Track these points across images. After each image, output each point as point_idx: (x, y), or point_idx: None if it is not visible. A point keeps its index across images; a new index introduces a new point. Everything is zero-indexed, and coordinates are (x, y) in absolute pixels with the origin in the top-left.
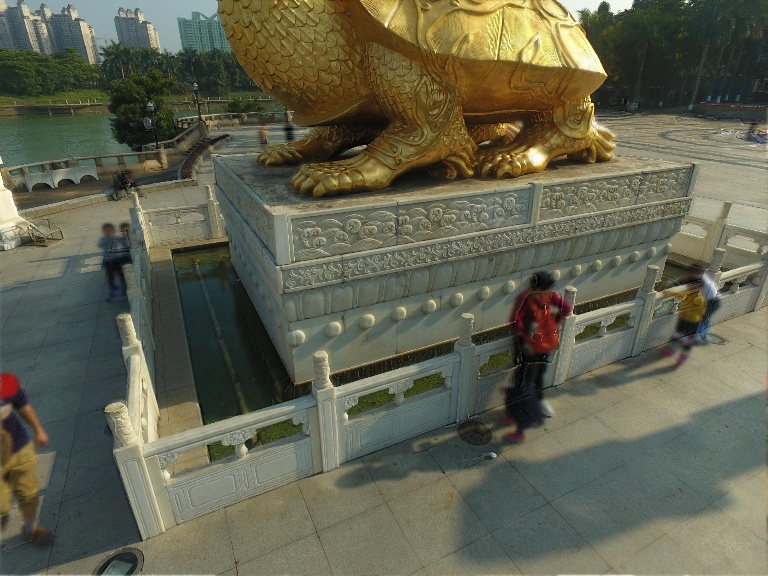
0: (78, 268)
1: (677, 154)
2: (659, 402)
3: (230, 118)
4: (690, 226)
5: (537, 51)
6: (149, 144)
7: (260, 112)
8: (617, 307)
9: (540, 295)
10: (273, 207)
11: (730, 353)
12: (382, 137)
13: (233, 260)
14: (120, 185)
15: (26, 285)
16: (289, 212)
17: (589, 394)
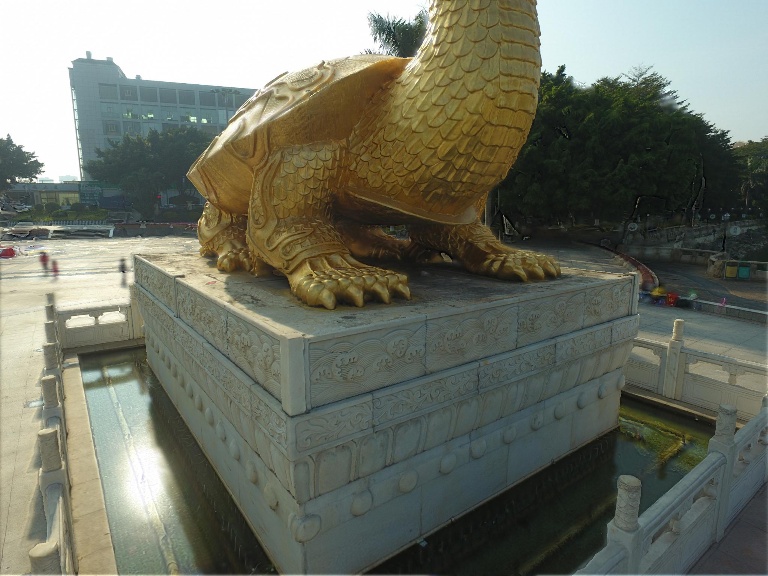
0: None
1: None
2: None
3: None
4: None
5: None
6: None
7: None
8: None
9: None
10: None
11: None
12: (480, 227)
13: None
14: None
15: None
16: None
17: None
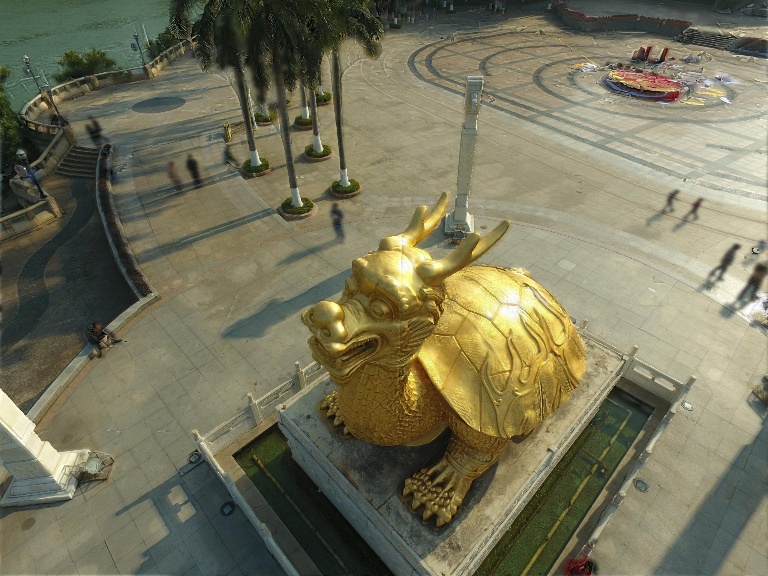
0: (174, 514)
1: (558, 130)
2: (629, 570)
3: (77, 86)
4: (599, 310)
5: (561, 396)
6: (16, 177)
7: (111, 70)
8: (606, 522)
9: (585, 573)
10: (426, 561)
11: (652, 501)
12: (462, 456)
13: (299, 463)
14: (97, 340)
15: (150, 557)
16: (444, 571)
17: (595, 574)
